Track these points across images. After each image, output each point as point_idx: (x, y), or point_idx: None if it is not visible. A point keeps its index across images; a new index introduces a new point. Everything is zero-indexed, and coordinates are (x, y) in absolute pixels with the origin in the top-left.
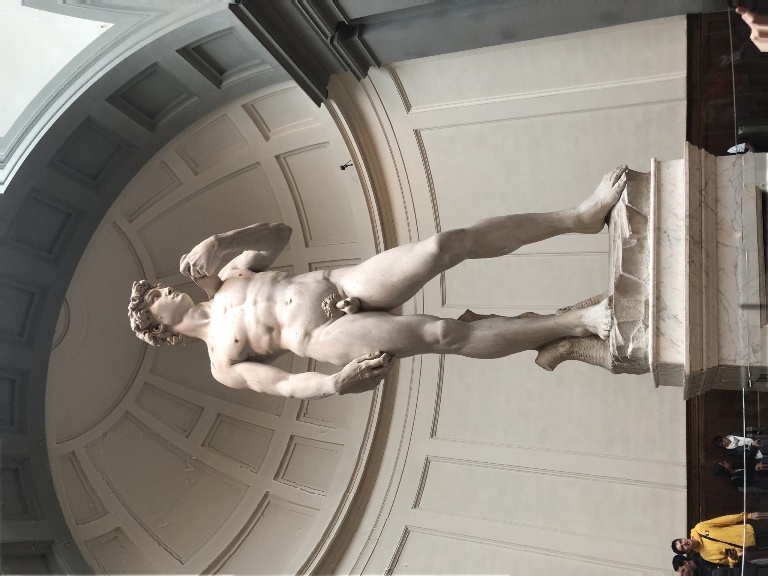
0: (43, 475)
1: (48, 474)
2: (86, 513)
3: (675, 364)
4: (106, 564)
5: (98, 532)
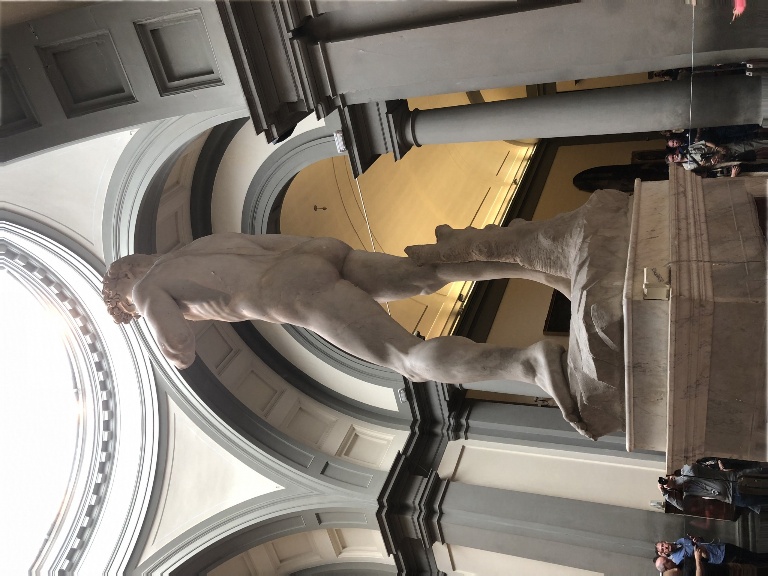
0: None
1: None
2: None
3: None
4: None
5: None
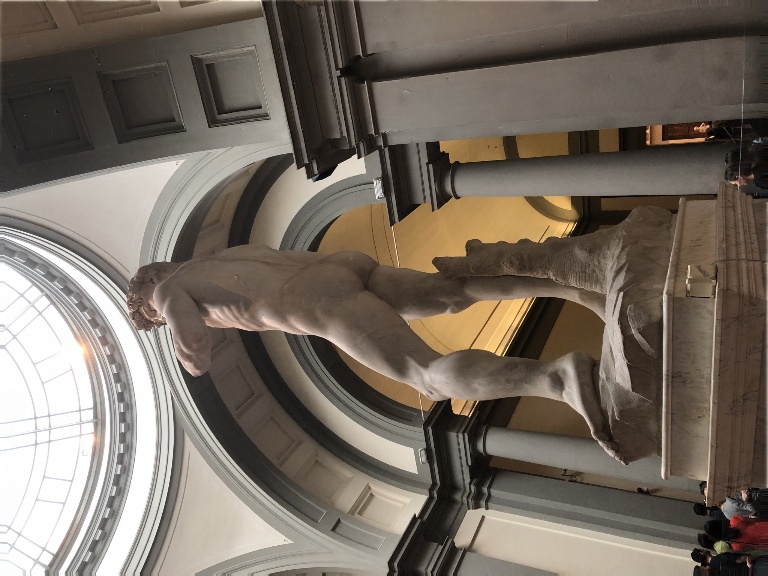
0: (7, 70)
1: (4, 65)
2: (32, 7)
3: None
4: (105, 3)
5: (63, 3)
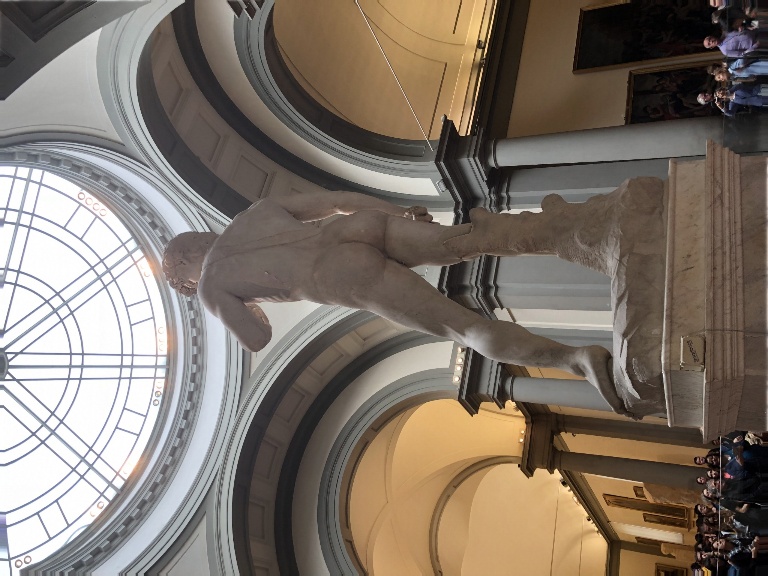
0: None
1: None
2: None
3: None
4: None
5: None
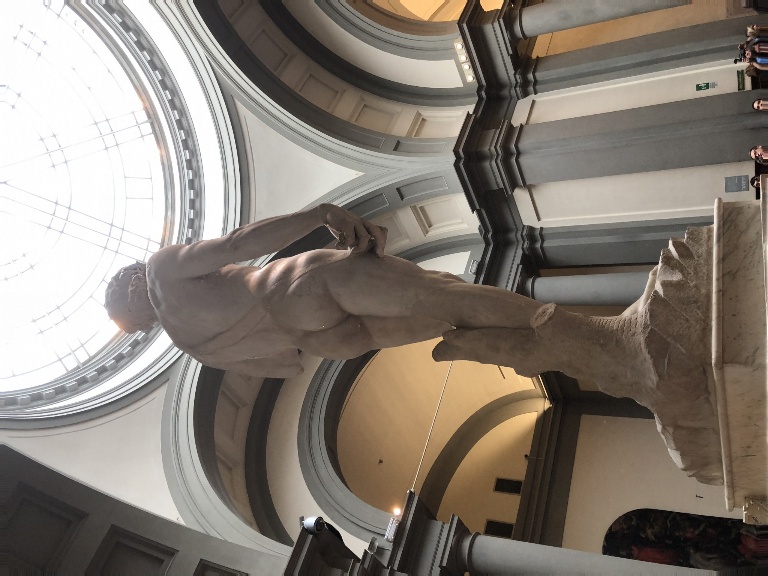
0: None
1: None
2: None
3: (748, 207)
4: None
5: None
